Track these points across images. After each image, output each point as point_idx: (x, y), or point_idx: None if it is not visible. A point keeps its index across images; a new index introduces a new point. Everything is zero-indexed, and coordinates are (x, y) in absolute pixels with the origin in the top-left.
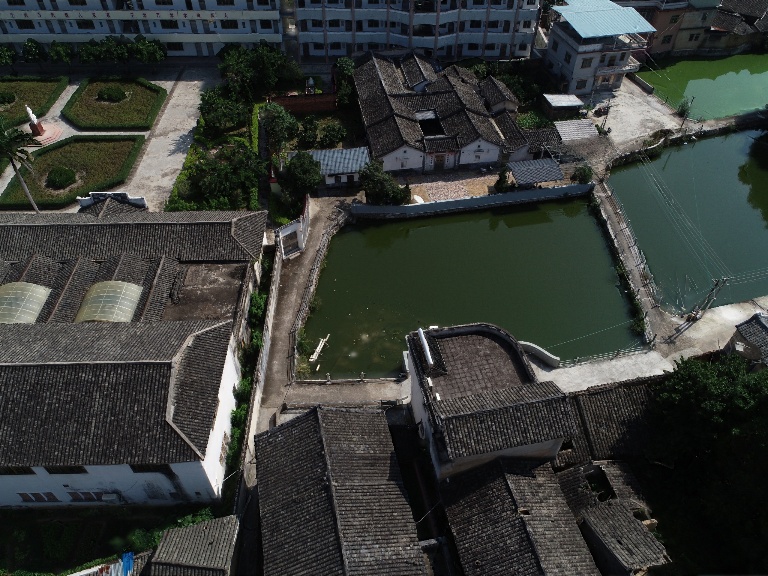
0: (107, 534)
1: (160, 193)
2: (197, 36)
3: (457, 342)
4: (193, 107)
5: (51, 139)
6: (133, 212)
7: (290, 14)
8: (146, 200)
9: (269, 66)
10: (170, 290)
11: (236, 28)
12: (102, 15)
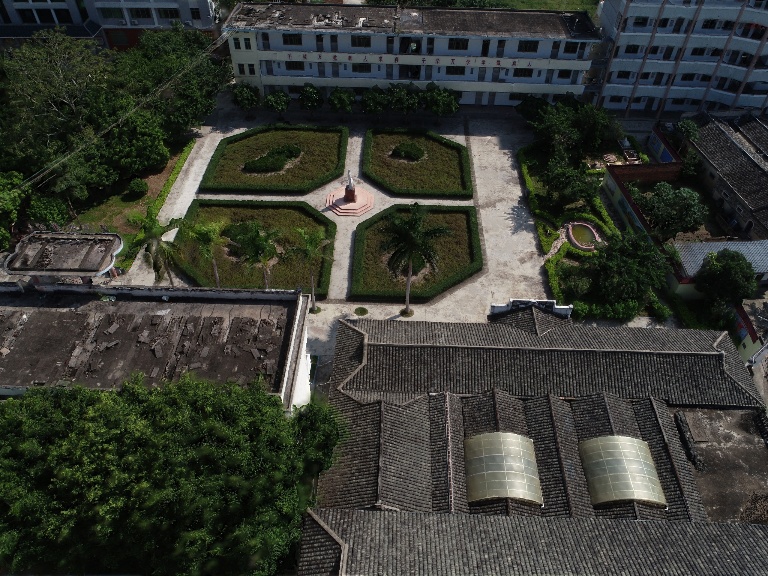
0: None
1: (531, 286)
2: (488, 85)
3: None
4: (505, 170)
5: (367, 207)
6: (561, 325)
7: (603, 65)
8: (520, 295)
9: (599, 127)
10: (683, 449)
11: (529, 76)
12: (390, 59)
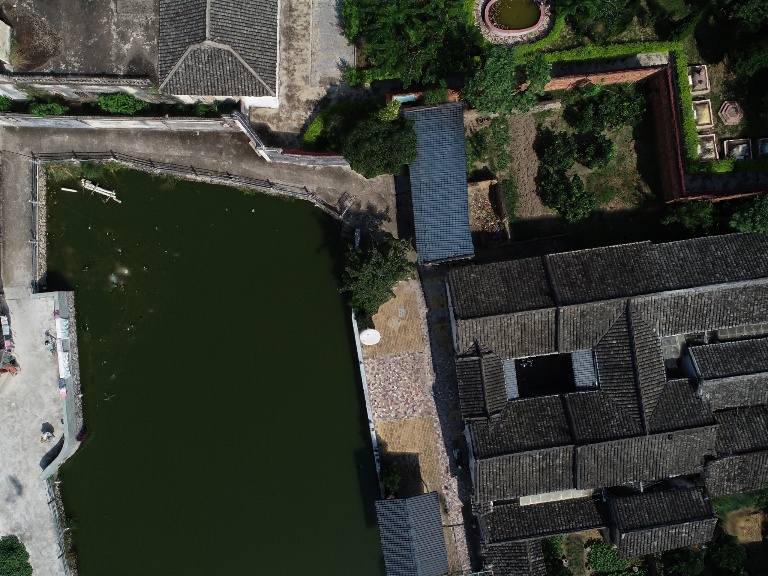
0: None
1: None
2: None
3: None
4: None
5: None
6: None
7: None
8: None
9: (767, 50)
10: None
11: None
12: None
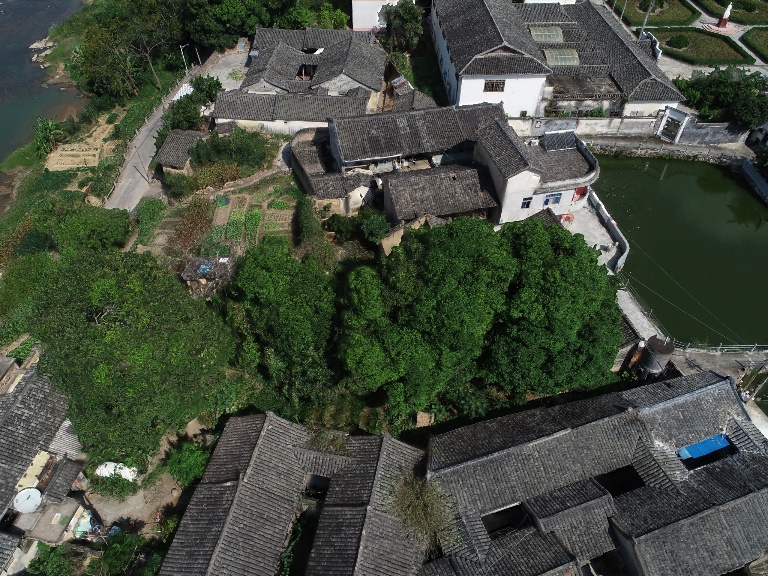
0: (435, 102)
1: None
2: None
3: (578, 157)
4: None
5: (719, 32)
6: (647, 54)
7: None
8: (682, 75)
9: None
10: None
11: None
12: None
